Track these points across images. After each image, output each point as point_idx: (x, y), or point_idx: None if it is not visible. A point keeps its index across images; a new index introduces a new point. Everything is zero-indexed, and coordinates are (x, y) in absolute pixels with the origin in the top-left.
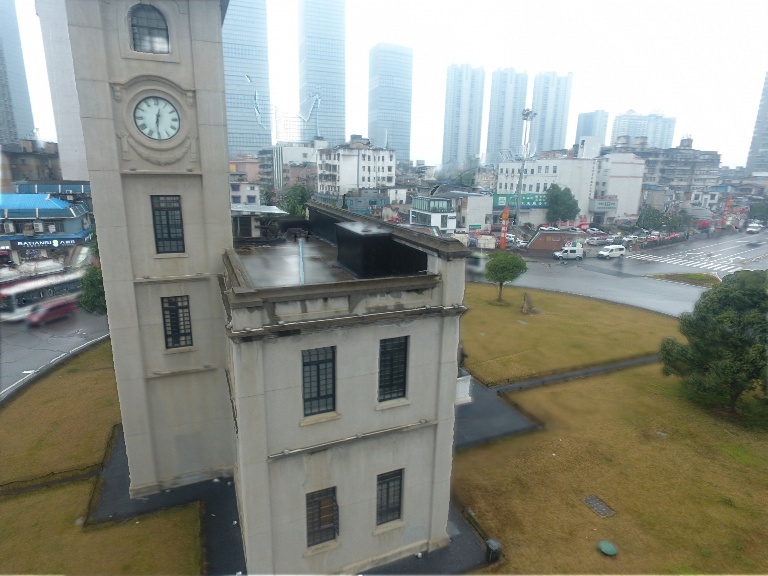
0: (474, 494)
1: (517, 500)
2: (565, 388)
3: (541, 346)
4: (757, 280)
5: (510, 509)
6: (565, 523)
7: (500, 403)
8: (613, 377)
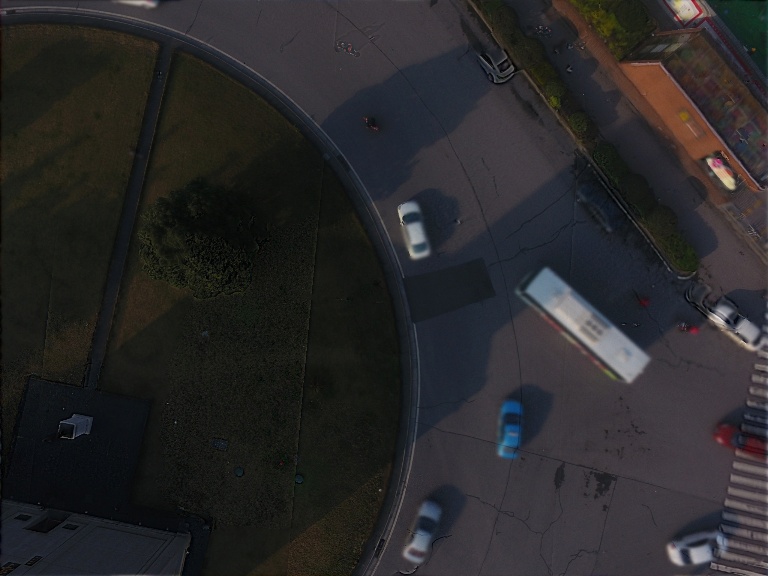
0: (172, 498)
1: (190, 481)
2: (123, 330)
3: (51, 268)
4: (169, 249)
5: (193, 491)
6: (217, 474)
7: (108, 399)
8: (135, 271)
